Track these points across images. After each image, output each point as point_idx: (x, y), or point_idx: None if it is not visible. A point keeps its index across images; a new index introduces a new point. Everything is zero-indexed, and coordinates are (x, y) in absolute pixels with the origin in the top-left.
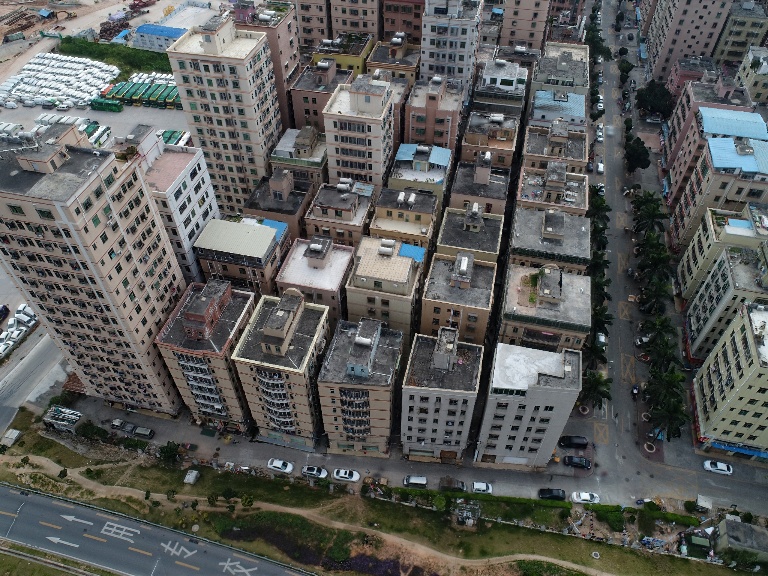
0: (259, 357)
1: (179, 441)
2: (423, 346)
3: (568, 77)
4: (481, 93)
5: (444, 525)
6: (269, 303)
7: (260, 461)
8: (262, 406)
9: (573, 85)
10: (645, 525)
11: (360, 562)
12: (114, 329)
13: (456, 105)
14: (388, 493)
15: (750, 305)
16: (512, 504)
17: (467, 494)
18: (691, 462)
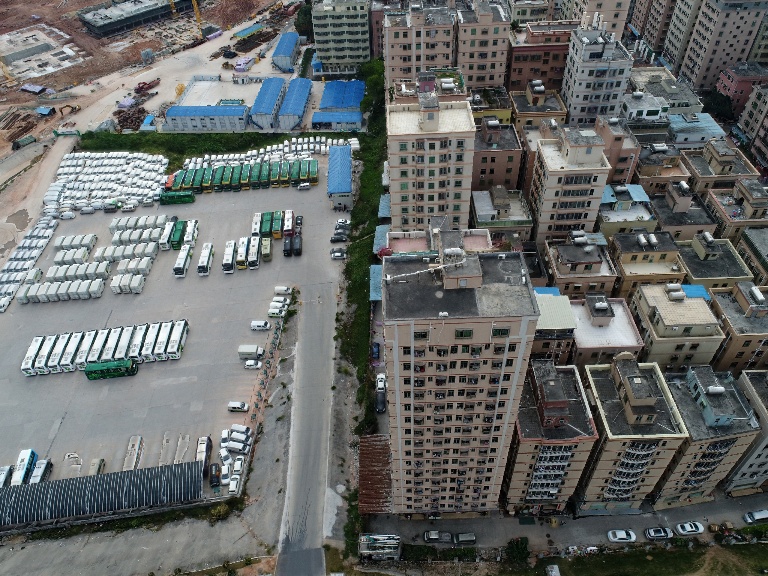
0: (629, 430)
1: (504, 538)
2: (754, 381)
3: (684, 99)
4: (629, 126)
5: None
6: (593, 372)
7: (597, 537)
8: (606, 479)
9: (688, 105)
10: None
11: None
12: (490, 437)
13: (630, 142)
14: (740, 536)
15: None
16: None
17: None
18: None
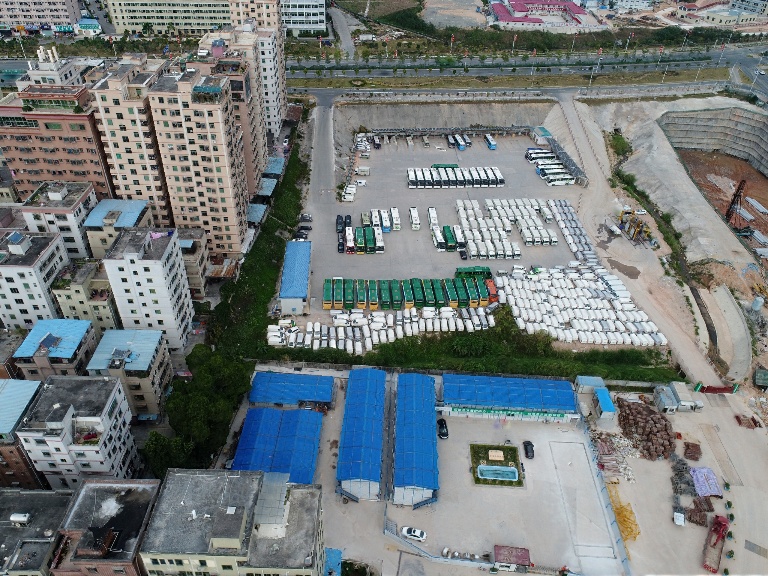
0: None
1: None
2: None
3: None
4: None
5: None
6: None
7: None
8: None
9: None
10: None
11: None
12: None
13: None
14: None
15: None
16: None
17: None
18: None
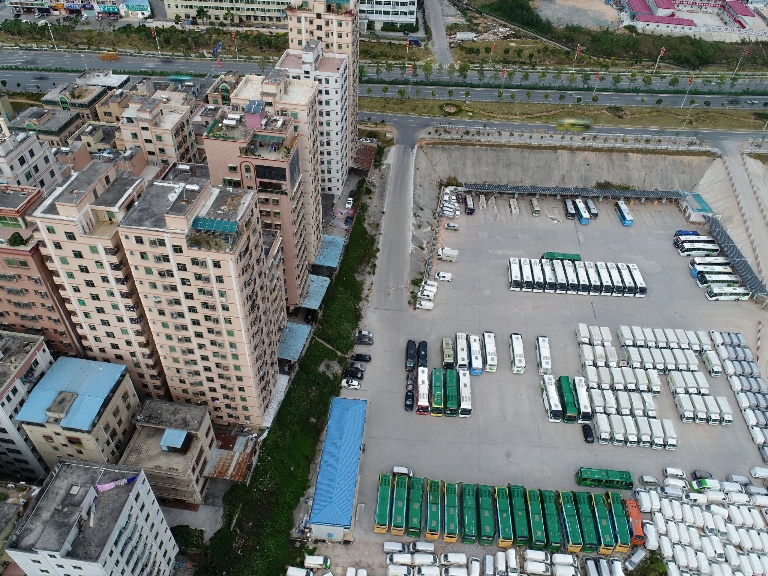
0: None
1: None
2: None
3: None
4: None
5: None
6: None
7: None
8: None
9: None
10: None
11: None
12: None
13: None
14: None
15: None
16: None
17: None
18: None
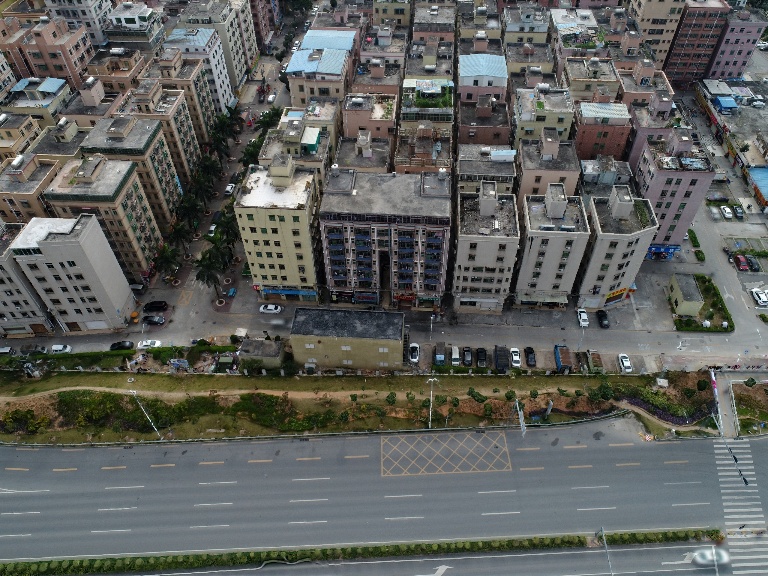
0: None
1: None
2: None
3: (205, 16)
4: (111, 32)
5: (14, 379)
6: None
7: None
8: None
9: (212, 23)
10: (190, 357)
11: None
12: None
13: None
14: None
15: (254, 167)
16: (84, 358)
17: (46, 355)
18: (251, 309)
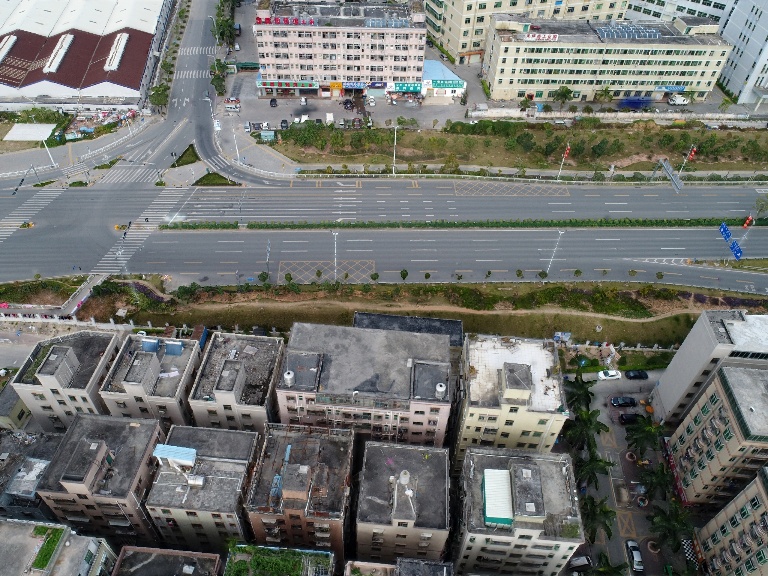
0: None
1: None
2: None
3: None
4: None
5: None
6: None
7: None
8: None
9: None
10: (561, 360)
11: (754, 302)
12: None
13: None
14: None
15: None
16: None
17: None
18: None
